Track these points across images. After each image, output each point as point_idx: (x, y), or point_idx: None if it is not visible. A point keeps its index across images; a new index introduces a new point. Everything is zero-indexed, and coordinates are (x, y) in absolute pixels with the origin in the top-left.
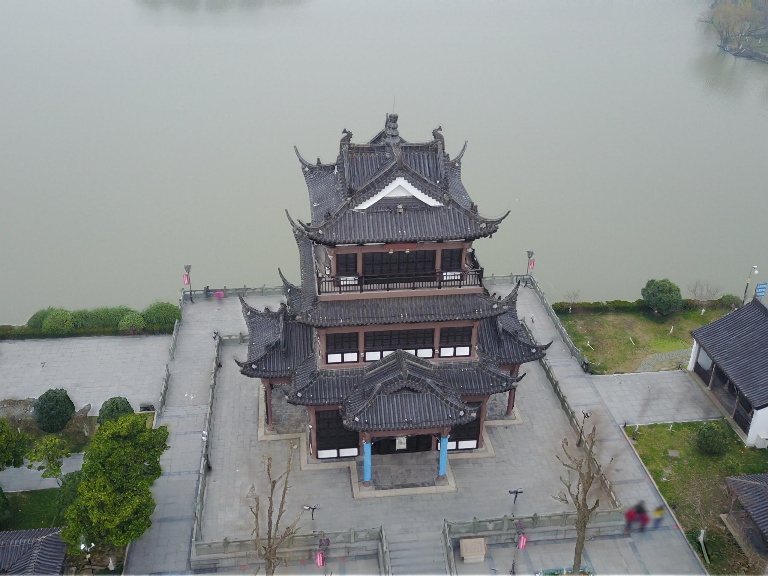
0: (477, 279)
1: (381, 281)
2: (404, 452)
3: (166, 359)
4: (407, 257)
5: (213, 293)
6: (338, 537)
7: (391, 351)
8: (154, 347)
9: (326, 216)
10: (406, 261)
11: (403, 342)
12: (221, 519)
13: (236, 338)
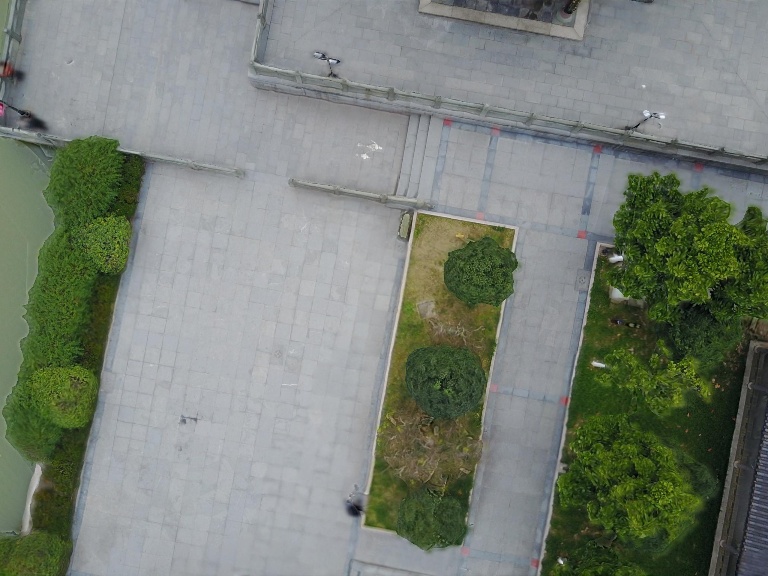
0: None
1: None
2: None
3: (235, 186)
4: None
5: (8, 62)
6: None
7: None
8: (184, 207)
9: None
10: None
11: None
12: (747, 126)
13: (259, 31)
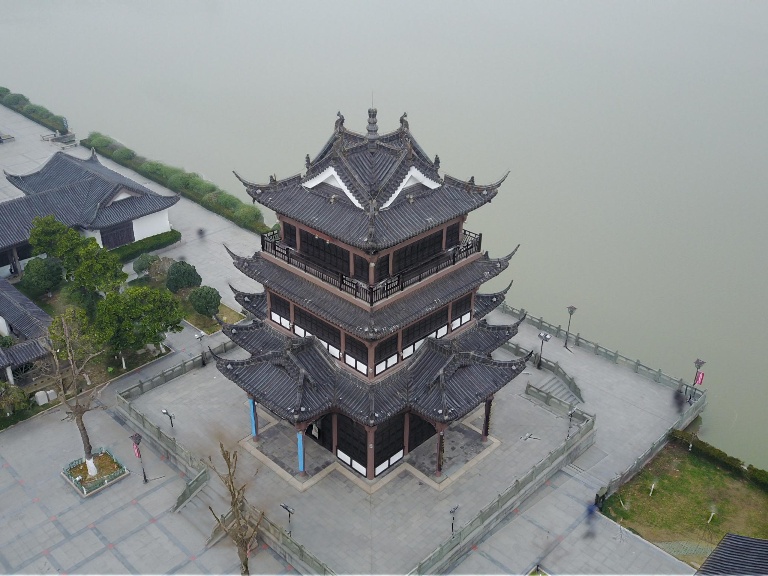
0: (369, 296)
1: (301, 260)
2: (315, 440)
3: None
4: (330, 248)
5: None
6: (183, 453)
7: (311, 334)
8: None
9: (271, 181)
10: (330, 252)
11: (320, 330)
12: (160, 396)
13: None
